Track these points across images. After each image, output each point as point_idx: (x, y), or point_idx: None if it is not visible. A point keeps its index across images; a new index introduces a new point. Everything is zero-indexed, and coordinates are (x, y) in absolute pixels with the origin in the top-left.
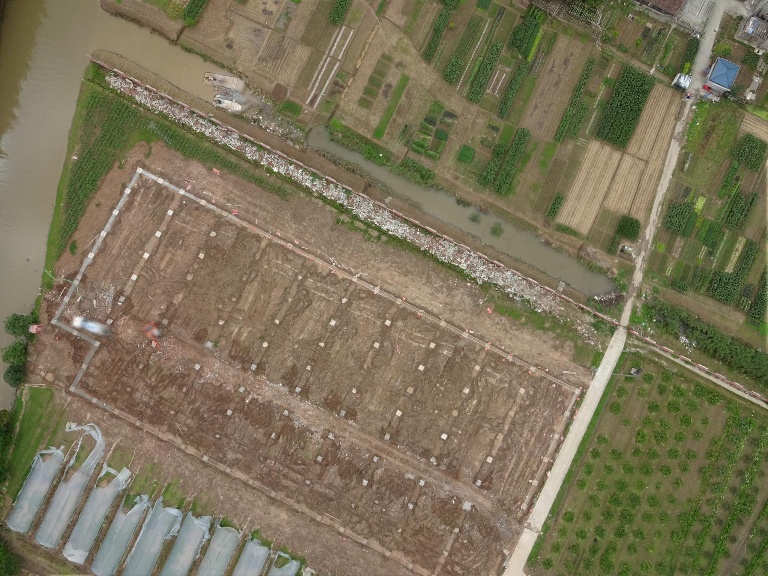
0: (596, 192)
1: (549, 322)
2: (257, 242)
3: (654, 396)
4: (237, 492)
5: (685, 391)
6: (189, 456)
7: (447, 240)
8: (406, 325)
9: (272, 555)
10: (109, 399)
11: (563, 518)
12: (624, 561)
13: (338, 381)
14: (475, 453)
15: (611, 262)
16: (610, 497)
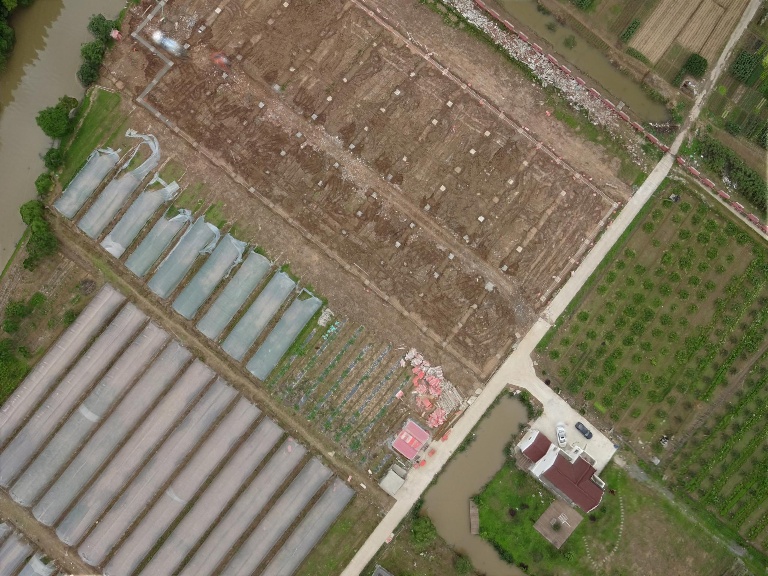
0: (672, 27)
1: (602, 136)
2: (341, 3)
3: (687, 225)
4: (276, 226)
5: (718, 225)
6: (237, 184)
7: (522, 38)
8: (466, 109)
9: (297, 291)
10: (172, 116)
11: (578, 316)
12: (627, 368)
13: (392, 145)
14: (507, 239)
15: (672, 93)
16: (626, 307)
